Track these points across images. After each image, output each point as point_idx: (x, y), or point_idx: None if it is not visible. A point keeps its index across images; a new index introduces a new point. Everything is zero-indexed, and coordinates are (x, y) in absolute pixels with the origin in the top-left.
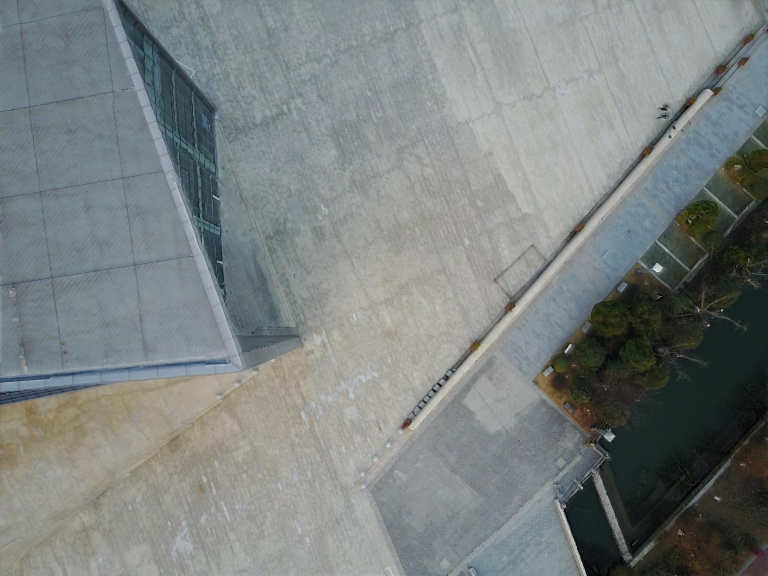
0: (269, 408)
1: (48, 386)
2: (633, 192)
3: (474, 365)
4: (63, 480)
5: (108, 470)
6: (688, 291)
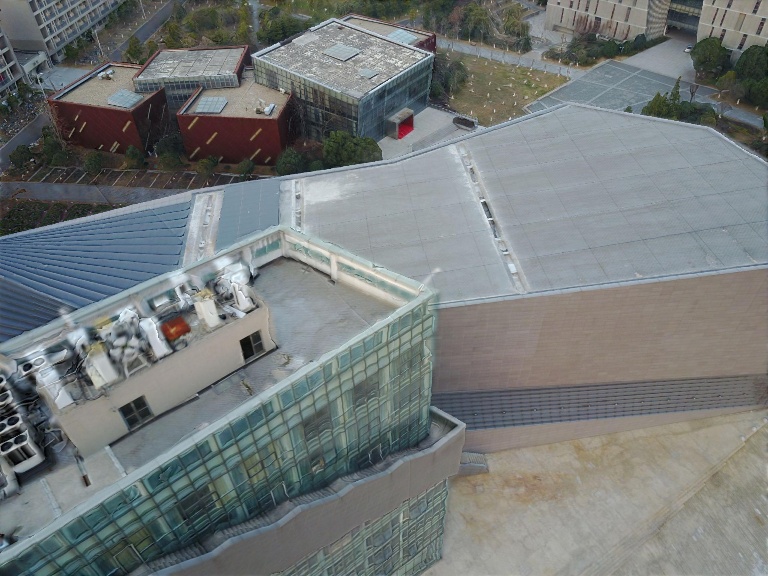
0: None
1: None
2: None
3: None
4: (625, 507)
5: (665, 498)
6: None
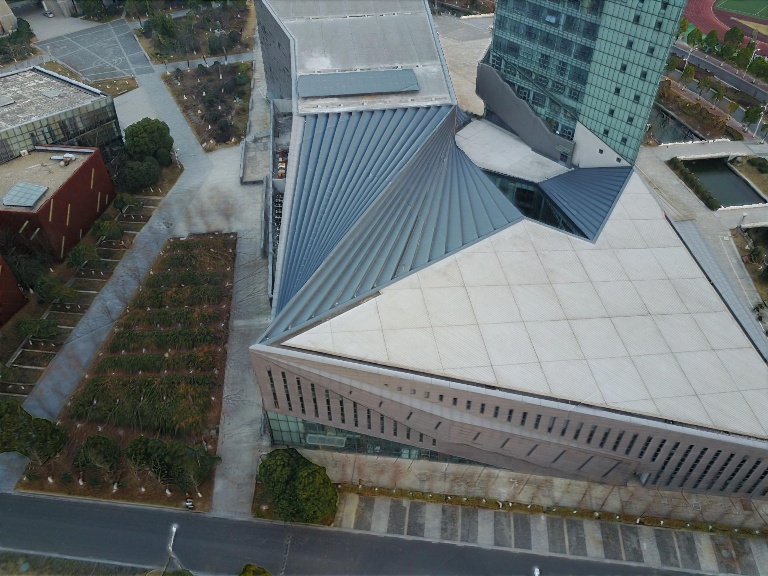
0: None
1: None
2: None
3: None
4: (467, 86)
5: None
6: None
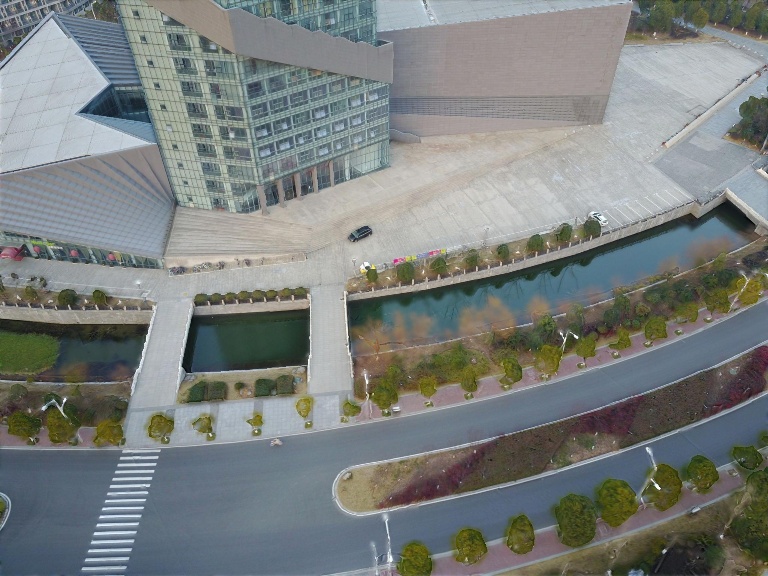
0: (591, 139)
1: (564, 11)
2: (738, 95)
3: (689, 133)
4: None
5: None
6: None
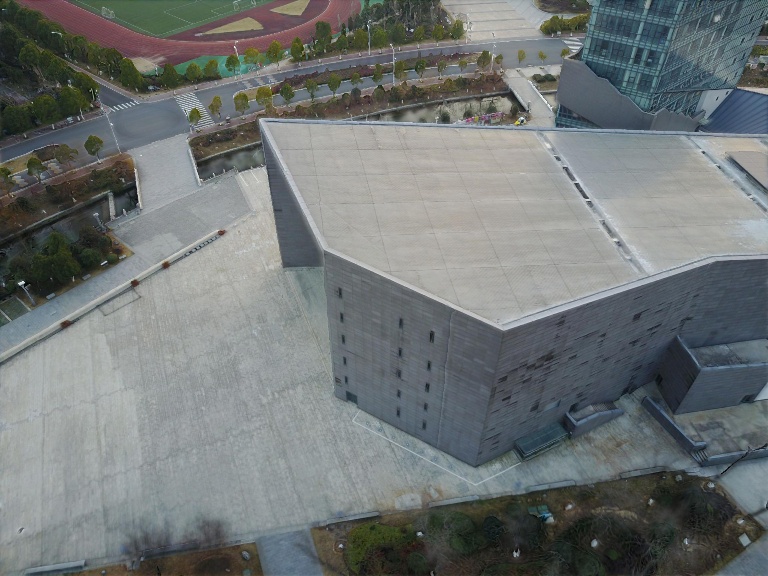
0: None
1: None
2: None
3: None
4: None
5: None
6: (5, 293)
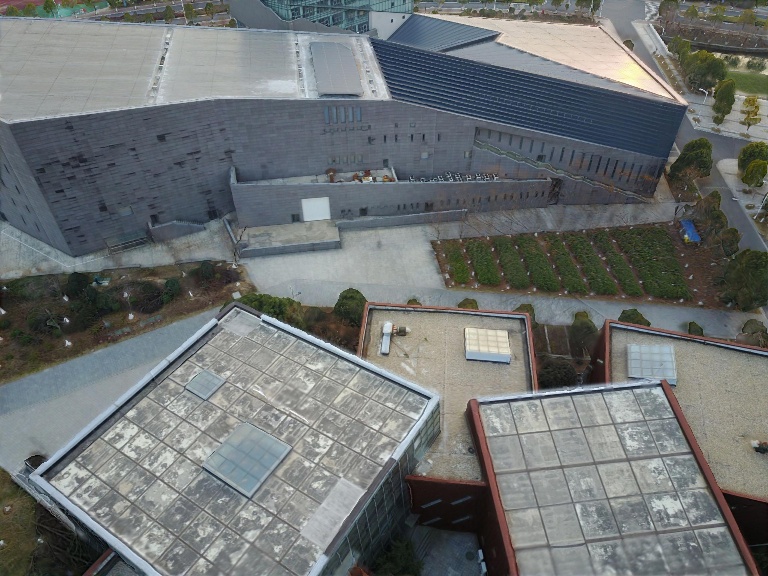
0: None
1: None
2: None
3: None
4: None
5: None
6: None
